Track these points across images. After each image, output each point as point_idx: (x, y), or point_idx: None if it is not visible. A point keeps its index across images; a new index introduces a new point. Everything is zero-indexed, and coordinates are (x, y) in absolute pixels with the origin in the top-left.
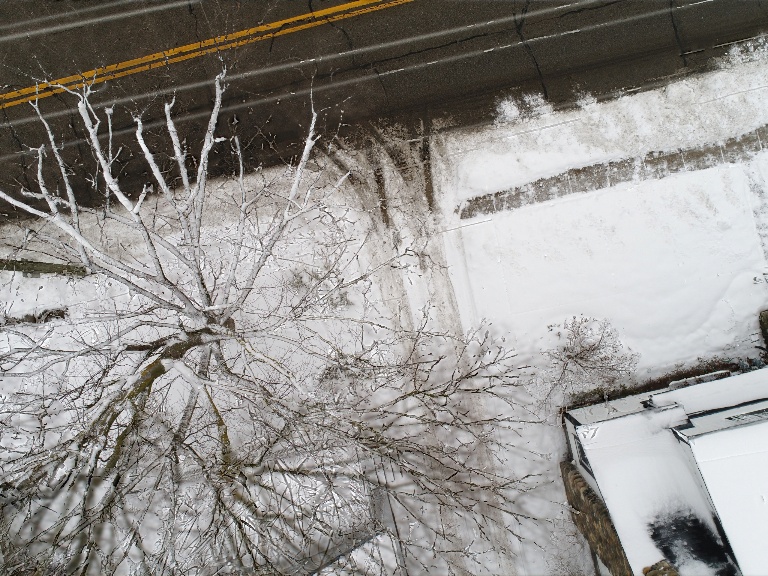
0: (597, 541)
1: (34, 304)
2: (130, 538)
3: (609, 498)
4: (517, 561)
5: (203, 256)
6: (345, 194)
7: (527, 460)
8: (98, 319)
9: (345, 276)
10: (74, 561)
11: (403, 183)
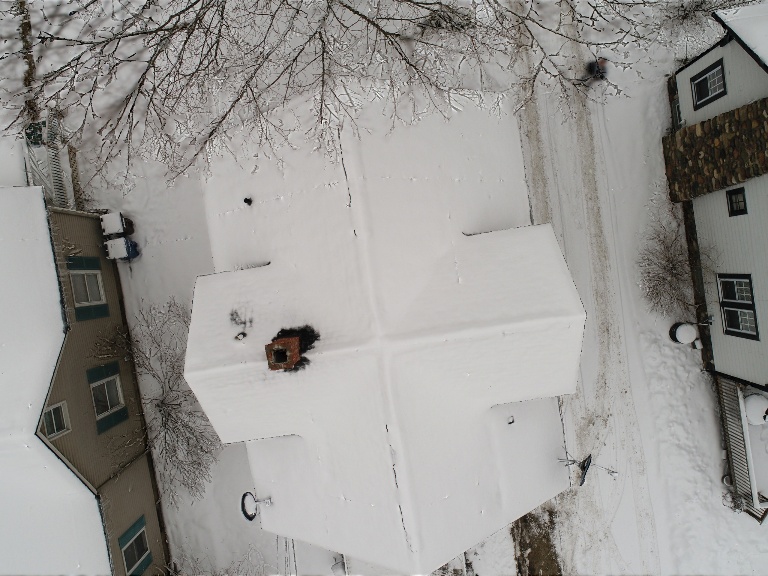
0: (714, 166)
1: None
2: None
3: (758, 46)
4: (608, 239)
5: None
6: None
7: (629, 131)
8: None
9: None
10: (144, 214)
11: None
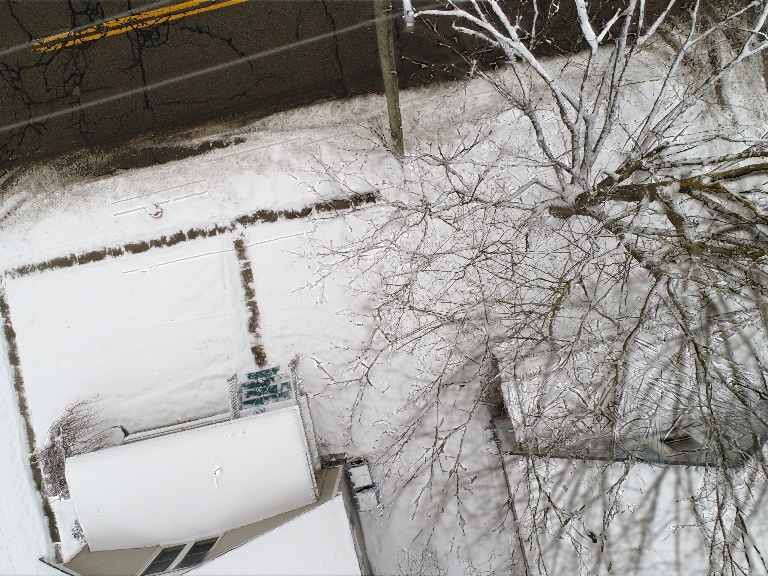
0: None
1: None
2: (693, 348)
3: None
4: None
5: (618, 106)
6: (679, 75)
7: None
8: (526, 163)
9: (687, 156)
10: None
11: (741, 63)
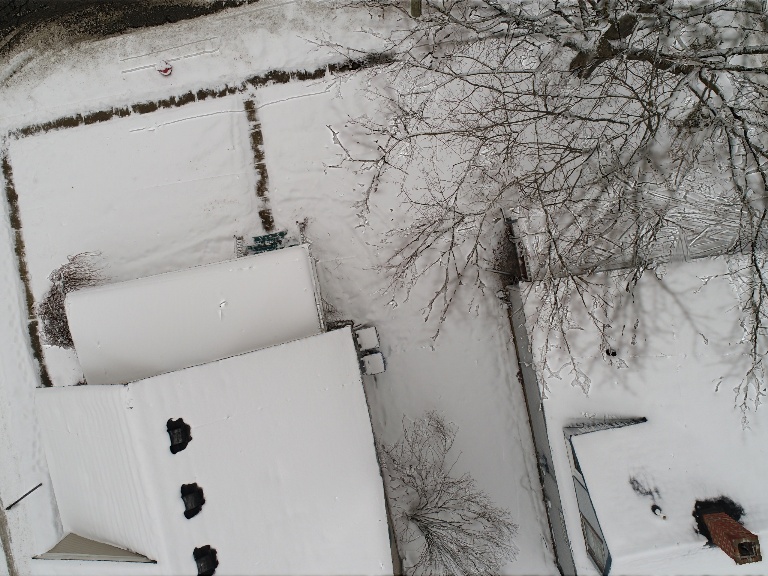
0: None
1: (361, 46)
2: (729, 110)
3: None
4: None
5: None
6: None
7: None
8: None
9: (713, 17)
10: (387, 323)
11: None
